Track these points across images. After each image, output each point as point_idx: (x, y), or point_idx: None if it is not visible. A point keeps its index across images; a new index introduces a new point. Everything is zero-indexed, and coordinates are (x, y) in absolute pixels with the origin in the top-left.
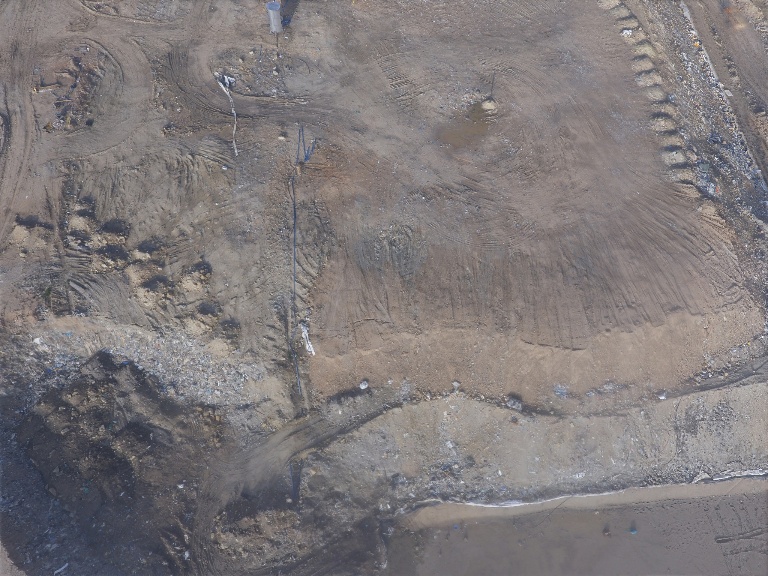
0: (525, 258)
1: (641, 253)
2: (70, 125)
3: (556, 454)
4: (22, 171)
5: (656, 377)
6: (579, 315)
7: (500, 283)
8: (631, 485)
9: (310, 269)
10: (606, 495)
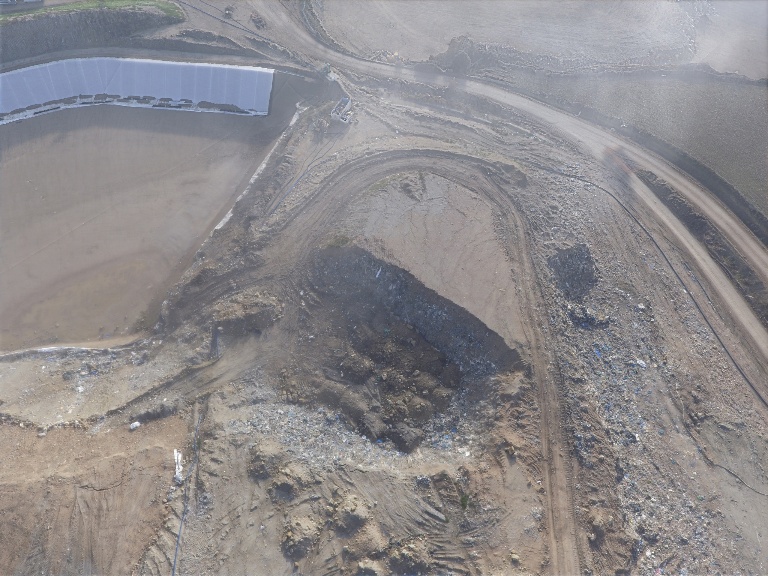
0: None
1: None
2: None
3: None
4: None
5: None
6: None
7: None
8: None
9: (157, 555)
10: None
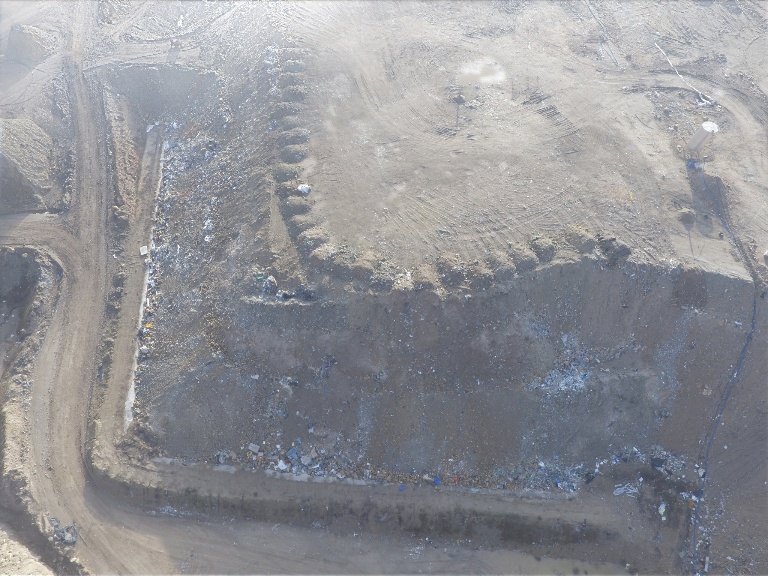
0: (424, 1)
1: (341, 5)
2: None
3: None
4: None
5: None
6: None
7: None
8: None
9: None
10: None
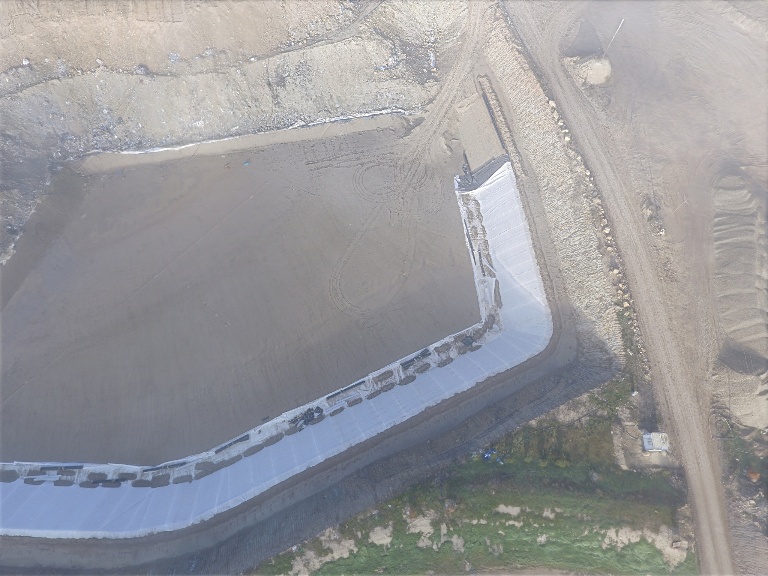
0: None
1: None
2: None
3: (176, 105)
4: None
5: (247, 45)
6: None
7: None
8: (246, 133)
9: None
10: (226, 141)
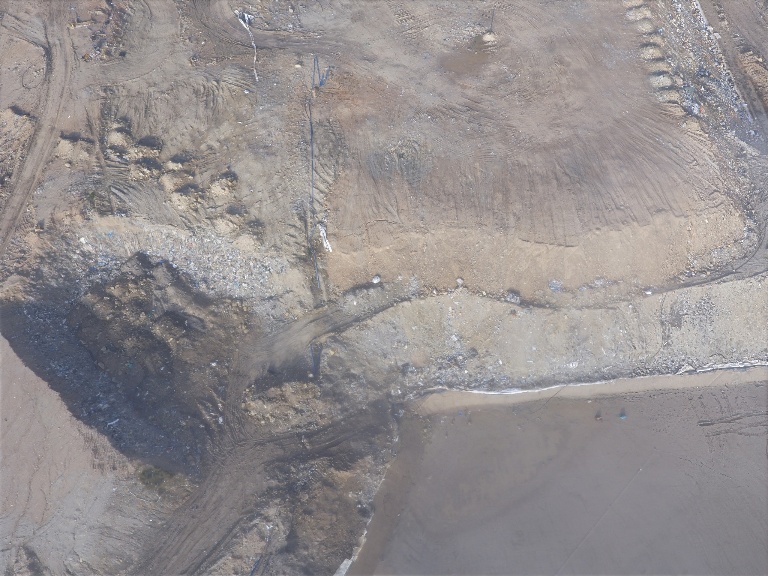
0: (522, 168)
1: (629, 163)
2: (105, 55)
3: (551, 344)
4: (64, 95)
5: (643, 274)
6: (572, 216)
7: (500, 189)
8: (621, 376)
9: (326, 177)
10: (598, 384)
